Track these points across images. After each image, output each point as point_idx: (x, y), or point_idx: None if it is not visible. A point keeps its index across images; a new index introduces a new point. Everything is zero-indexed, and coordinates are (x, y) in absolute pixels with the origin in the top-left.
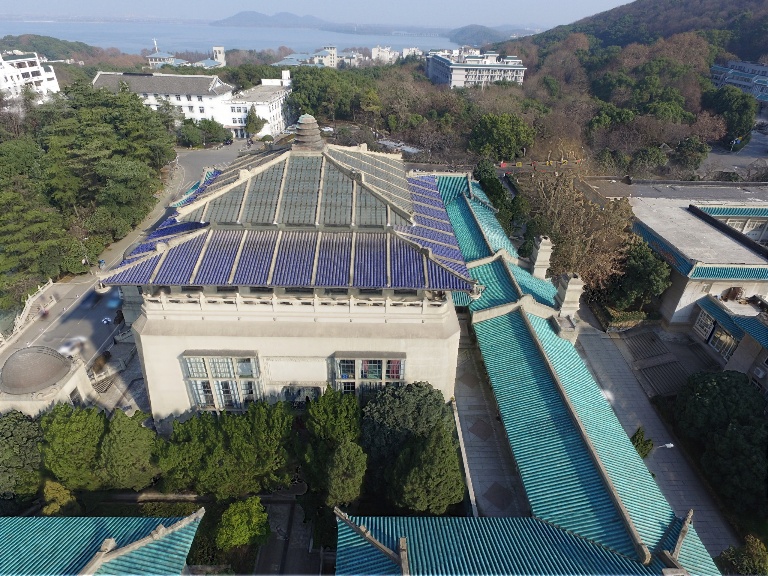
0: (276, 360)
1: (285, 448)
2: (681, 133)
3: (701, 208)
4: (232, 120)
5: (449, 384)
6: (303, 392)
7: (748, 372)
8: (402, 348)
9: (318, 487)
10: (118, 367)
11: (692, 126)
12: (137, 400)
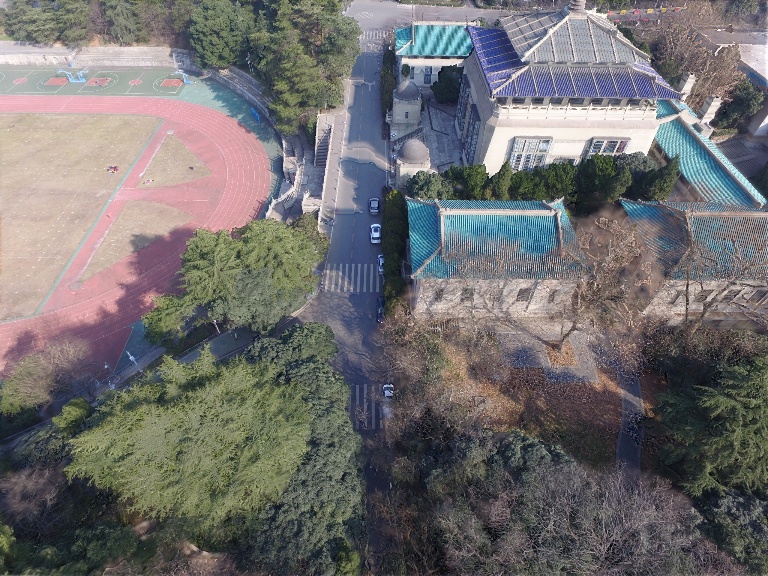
0: (559, 142)
1: None
2: None
3: None
4: None
5: None
6: (561, 163)
7: None
8: (629, 135)
9: (588, 202)
10: None
11: None
12: None
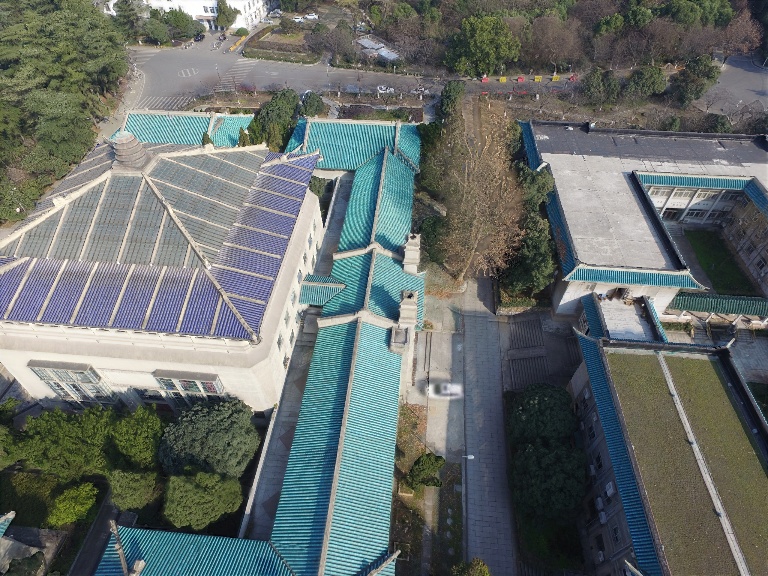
0: (109, 371)
1: (105, 452)
2: (702, 43)
3: (644, 176)
4: (203, 9)
5: (268, 396)
6: None
7: (583, 388)
8: (213, 371)
9: None
10: None
11: (720, 33)
12: None
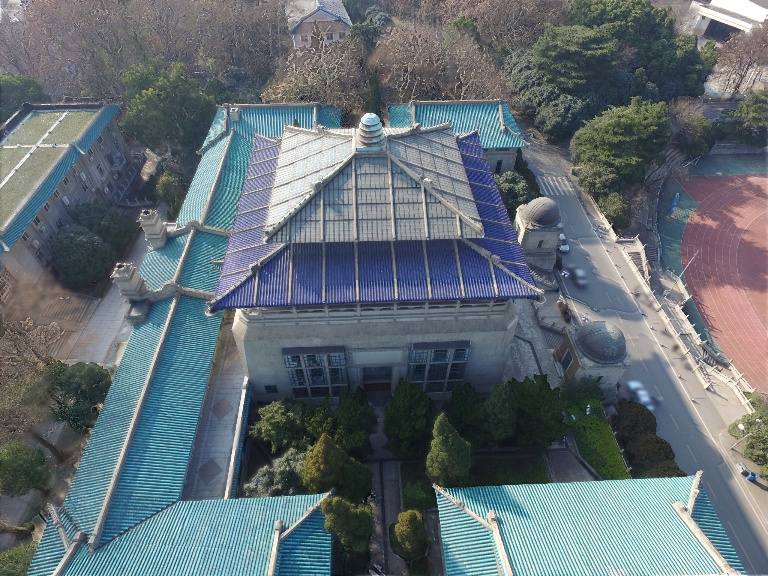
0: None
1: None
2: None
3: None
4: None
5: None
6: None
7: None
8: None
9: None
10: None
11: None
12: None
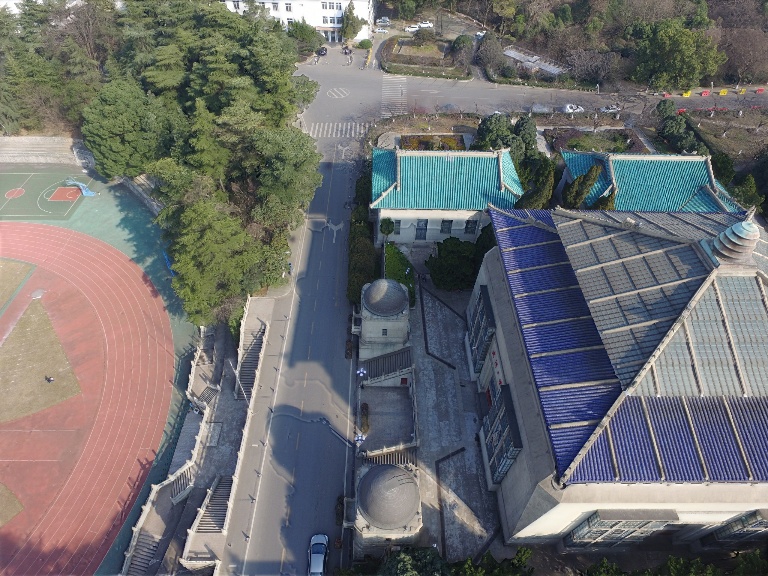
0: (687, 513)
1: None
2: None
3: None
4: (322, 19)
5: None
6: None
7: None
8: None
9: None
10: (412, 444)
11: None
12: (457, 492)
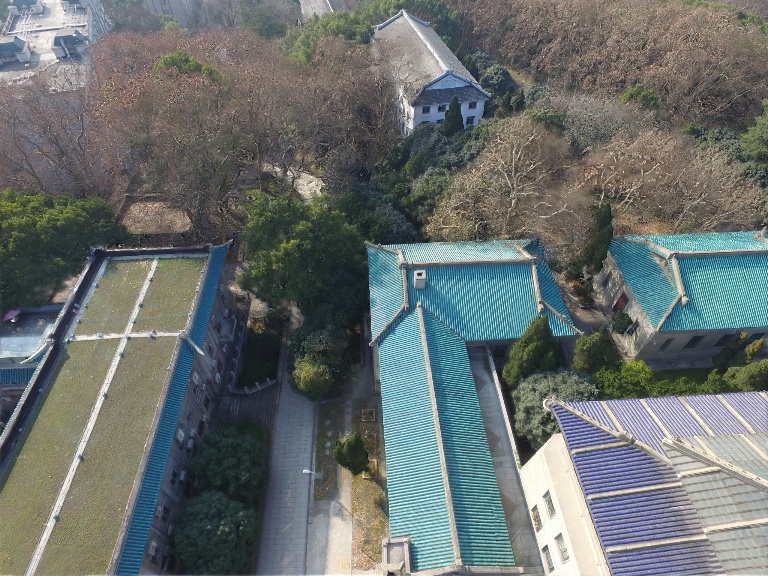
0: None
1: None
2: None
3: None
4: None
5: None
6: None
7: (149, 569)
8: None
9: None
10: None
11: None
12: None
